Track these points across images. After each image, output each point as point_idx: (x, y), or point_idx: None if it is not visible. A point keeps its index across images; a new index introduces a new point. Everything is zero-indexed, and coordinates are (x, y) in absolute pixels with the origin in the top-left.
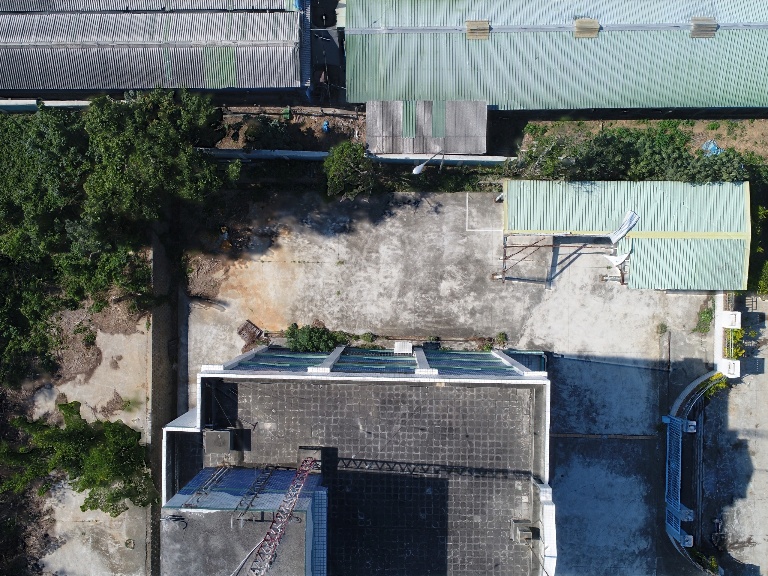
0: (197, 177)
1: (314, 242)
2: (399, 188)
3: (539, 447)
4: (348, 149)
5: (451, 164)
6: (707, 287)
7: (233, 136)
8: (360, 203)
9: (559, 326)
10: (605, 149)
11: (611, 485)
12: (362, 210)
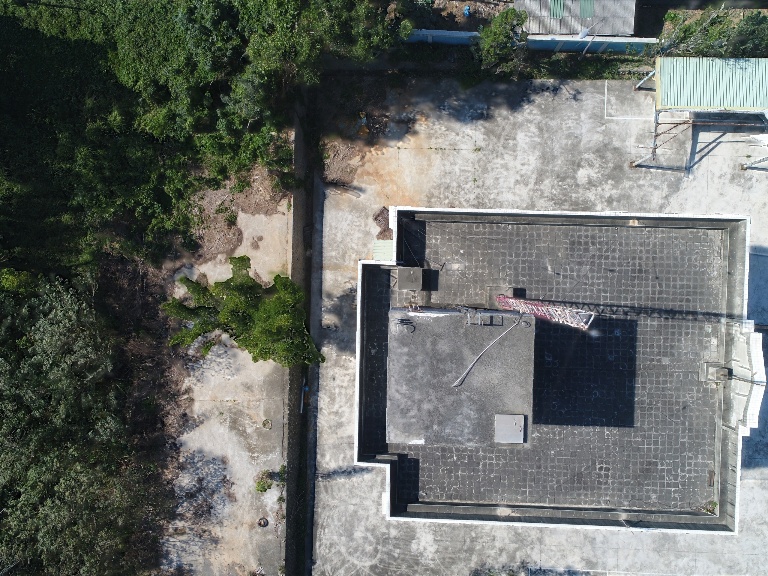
0: (370, 33)
1: (451, 129)
2: (537, 76)
3: (733, 287)
4: (513, 14)
5: (591, 51)
6: None
7: (382, 13)
8: (498, 90)
9: None
10: (758, 28)
11: None
12: (500, 97)
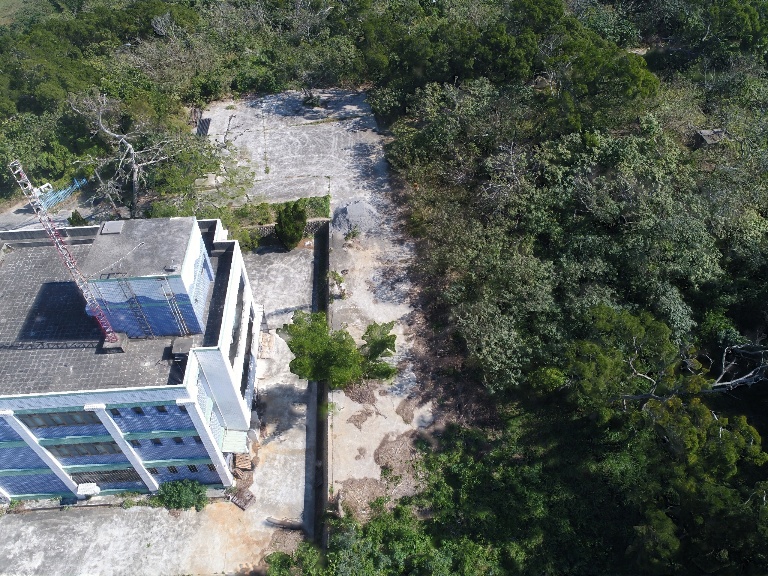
0: None
1: None
2: None
3: None
4: None
5: None
6: None
7: None
8: None
9: None
10: None
11: None
12: None
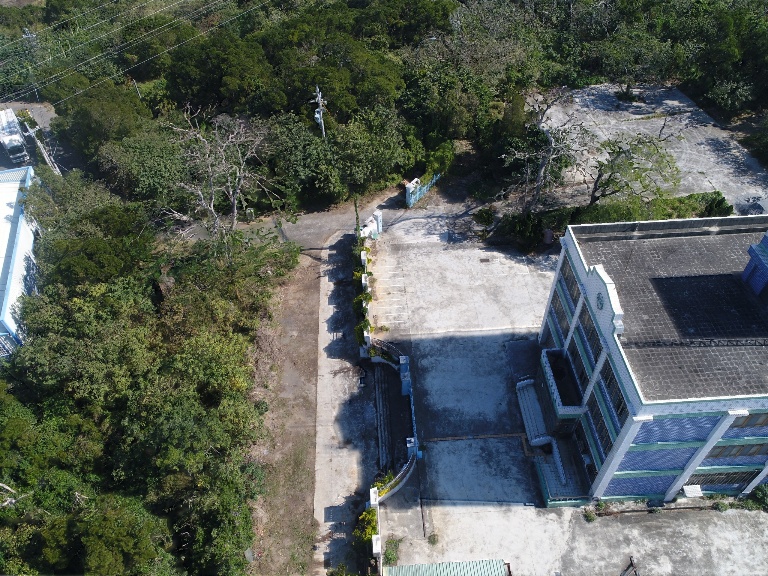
0: None
1: None
2: None
3: None
4: None
5: None
6: (423, 567)
7: None
8: None
9: (536, 534)
10: None
11: (458, 401)
12: None
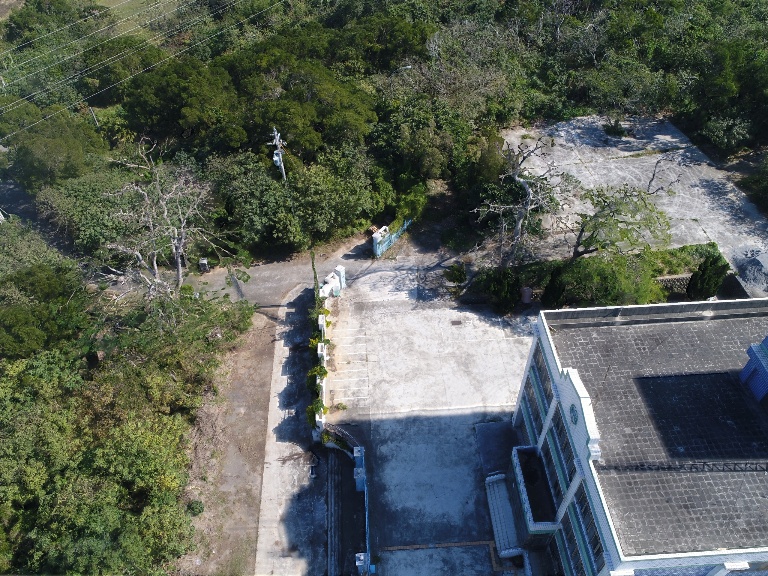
0: None
1: None
2: None
3: None
4: None
5: None
6: None
7: None
8: None
9: None
10: None
11: (419, 498)
12: None
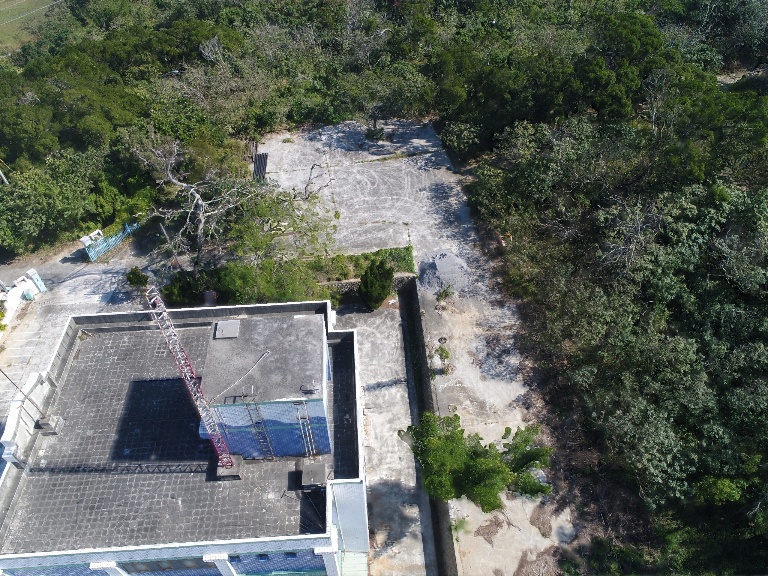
0: None
1: None
2: None
3: (8, 497)
4: None
5: None
6: None
7: None
8: None
9: None
10: None
11: None
12: None
